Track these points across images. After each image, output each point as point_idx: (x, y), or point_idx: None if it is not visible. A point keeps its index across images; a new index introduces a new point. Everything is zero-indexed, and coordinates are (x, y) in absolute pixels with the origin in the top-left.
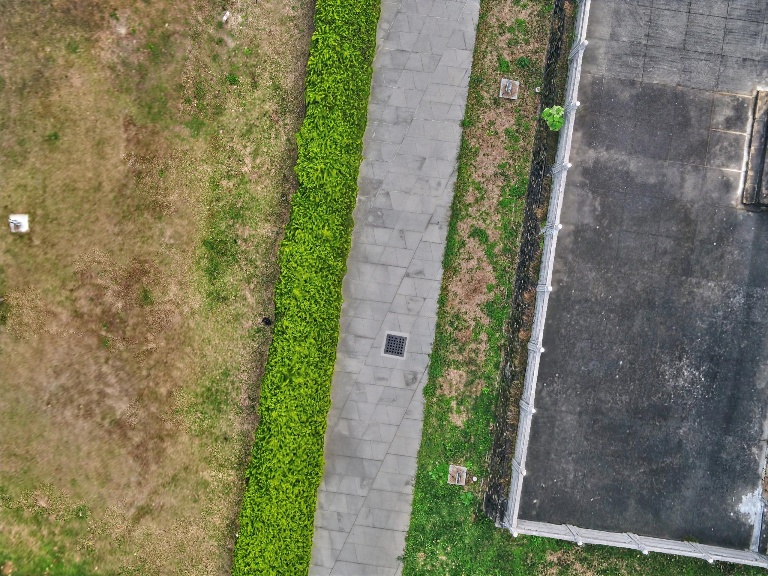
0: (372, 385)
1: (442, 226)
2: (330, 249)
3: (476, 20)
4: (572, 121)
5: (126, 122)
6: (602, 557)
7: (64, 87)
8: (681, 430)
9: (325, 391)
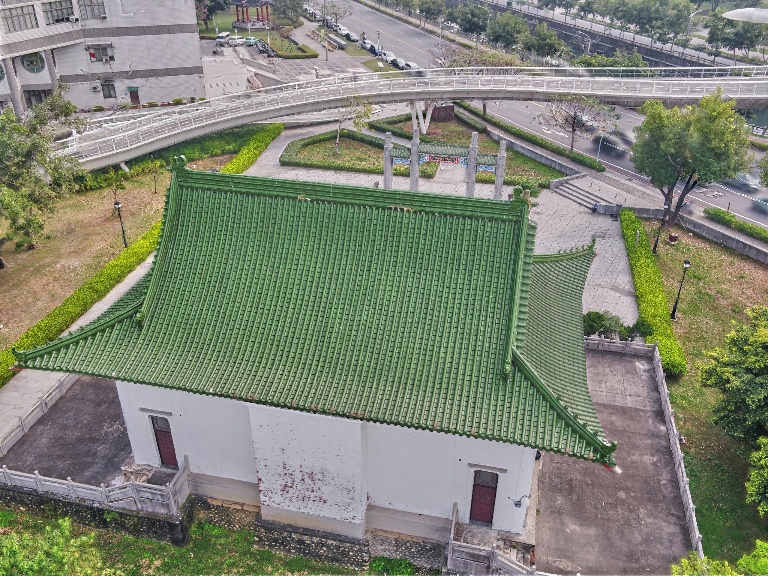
0: None
1: (44, 393)
2: None
3: None
4: None
5: None
6: (32, 533)
7: None
8: (99, 448)
9: None
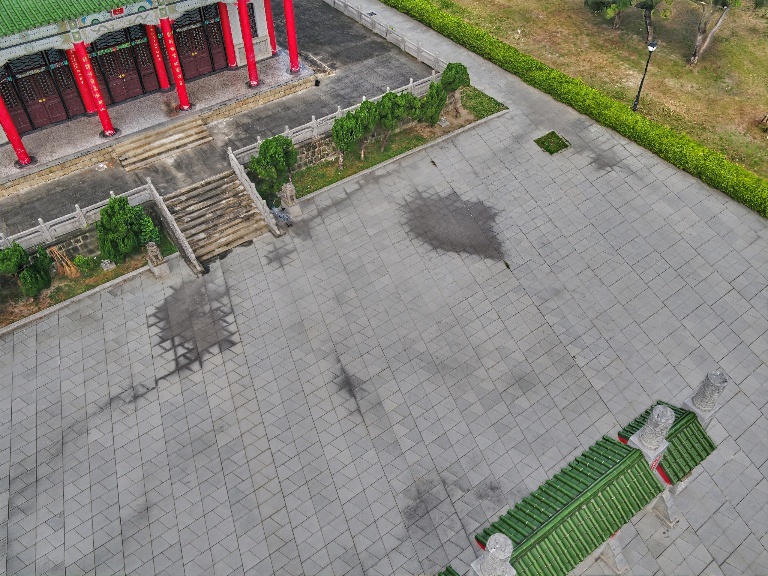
0: (367, 6)
1: None
2: (417, 7)
3: None
4: None
5: (510, 6)
6: None
7: (536, 2)
8: None
9: None
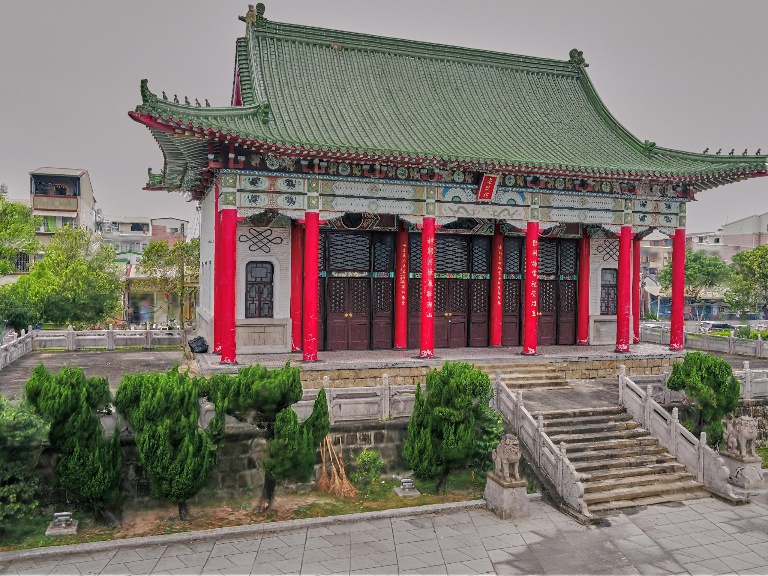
0: None
1: None
2: None
3: None
4: None
5: None
6: None
7: None
8: None
9: None
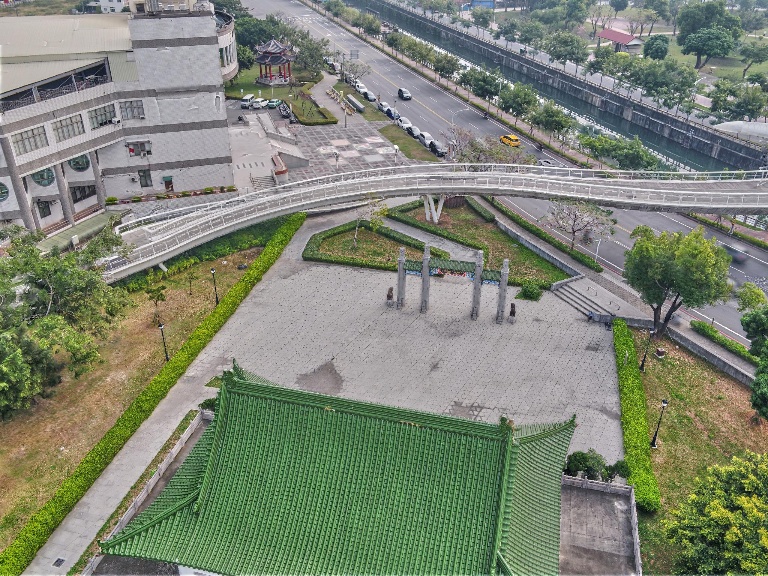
0: None
1: (104, 521)
2: (52, 517)
3: (154, 458)
4: (156, 472)
5: (3, 475)
6: None
7: None
8: None
9: (15, 569)
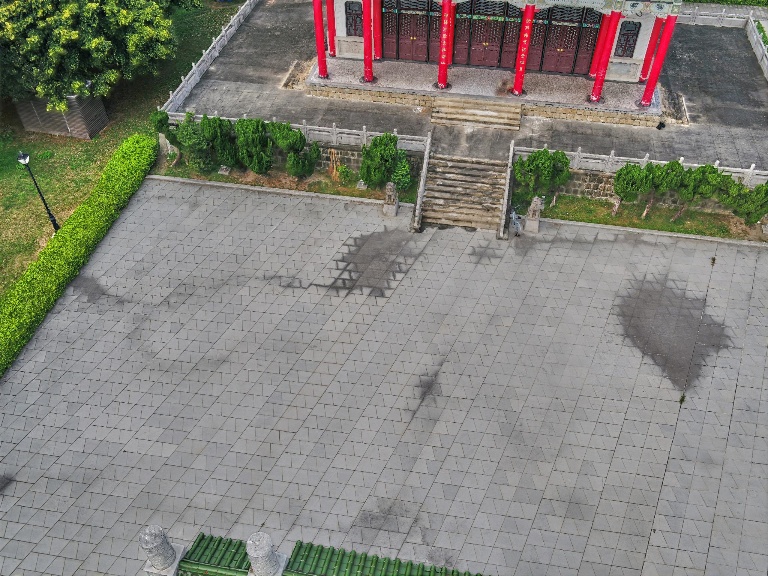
0: None
1: None
2: None
3: None
4: None
5: None
6: None
7: None
8: None
9: None
